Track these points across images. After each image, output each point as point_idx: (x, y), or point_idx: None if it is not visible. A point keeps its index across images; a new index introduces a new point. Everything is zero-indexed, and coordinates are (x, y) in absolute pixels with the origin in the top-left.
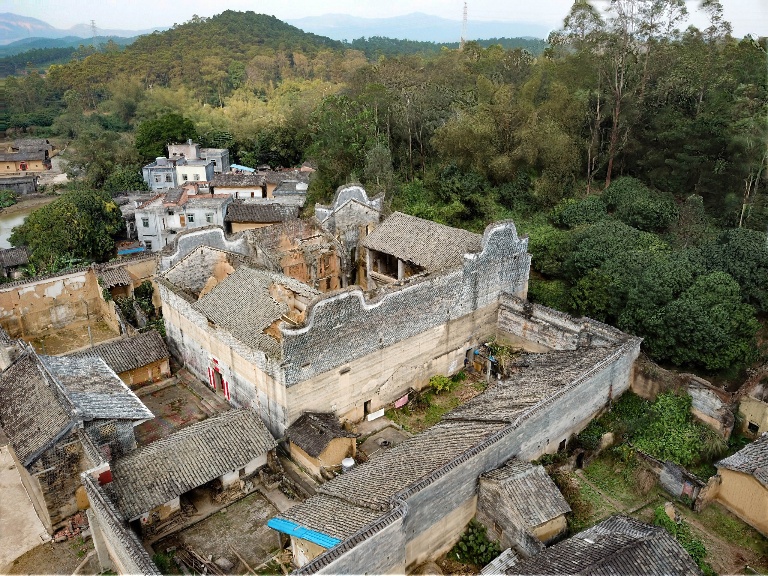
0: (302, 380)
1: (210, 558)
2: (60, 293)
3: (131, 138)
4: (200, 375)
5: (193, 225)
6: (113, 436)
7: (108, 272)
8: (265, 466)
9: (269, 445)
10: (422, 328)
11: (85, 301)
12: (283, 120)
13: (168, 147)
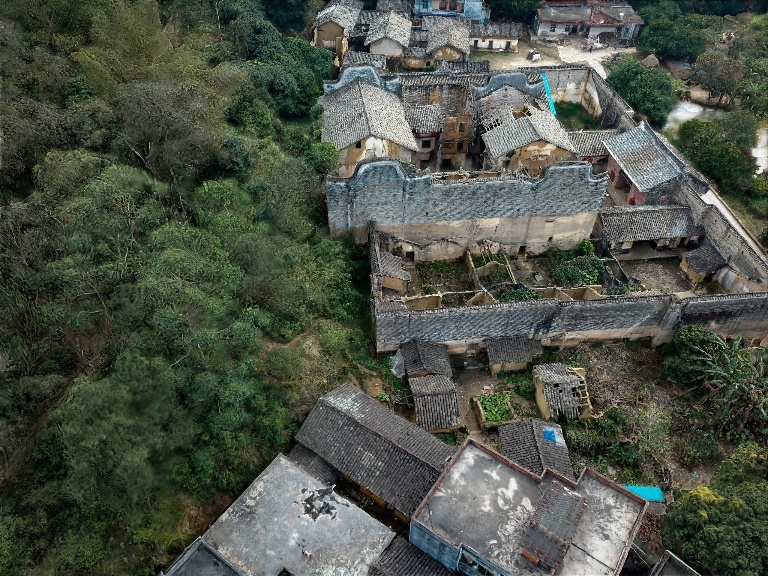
0: None
1: None
2: None
3: None
4: None
5: None
6: None
7: None
8: None
9: None
10: None
11: None
12: None
13: None
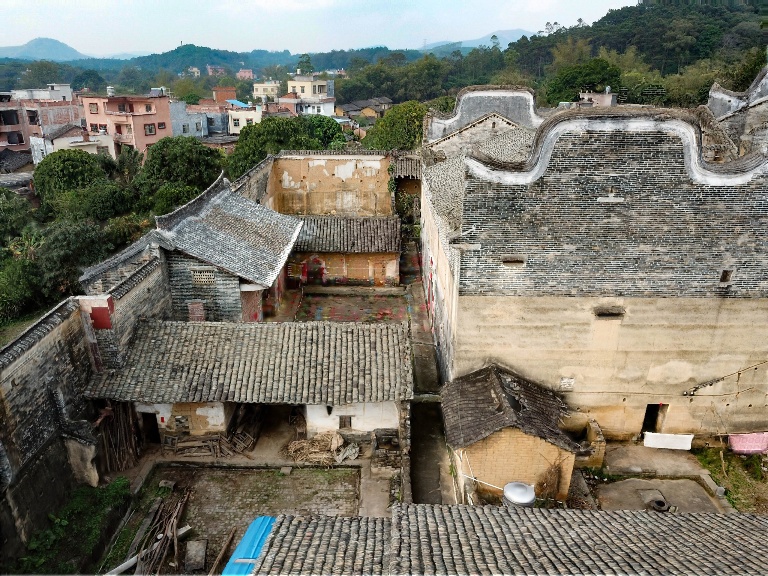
0: (499, 292)
1: (182, 530)
2: (350, 176)
3: (546, 88)
4: (426, 289)
5: None
6: (210, 293)
7: (405, 161)
8: (394, 433)
9: (396, 392)
10: None
11: (375, 193)
12: (742, 65)
13: (580, 95)
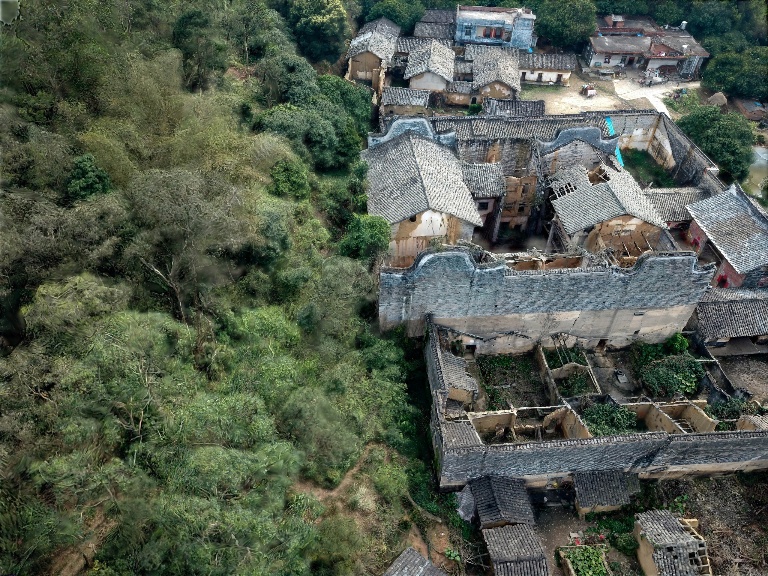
0: None
1: None
2: None
3: None
4: None
5: None
6: None
7: None
8: None
9: None
10: None
11: None
12: None
13: None
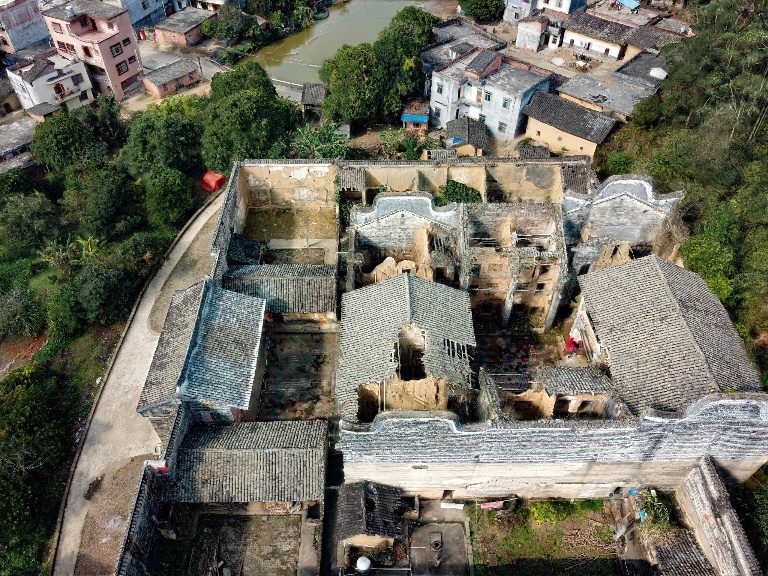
0: (364, 462)
1: (220, 565)
2: (304, 177)
3: None
4: None
5: (488, 104)
6: (213, 409)
7: (348, 171)
8: None
9: (315, 495)
10: (545, 459)
11: (326, 188)
12: None
13: None
